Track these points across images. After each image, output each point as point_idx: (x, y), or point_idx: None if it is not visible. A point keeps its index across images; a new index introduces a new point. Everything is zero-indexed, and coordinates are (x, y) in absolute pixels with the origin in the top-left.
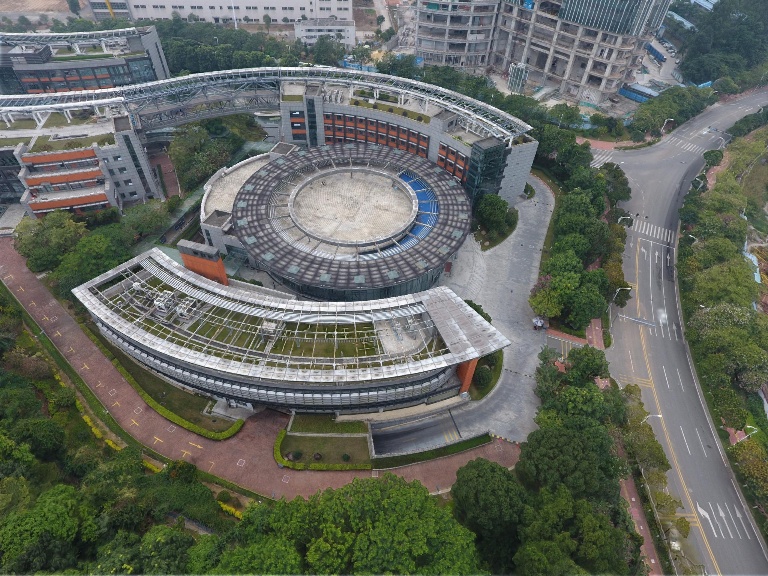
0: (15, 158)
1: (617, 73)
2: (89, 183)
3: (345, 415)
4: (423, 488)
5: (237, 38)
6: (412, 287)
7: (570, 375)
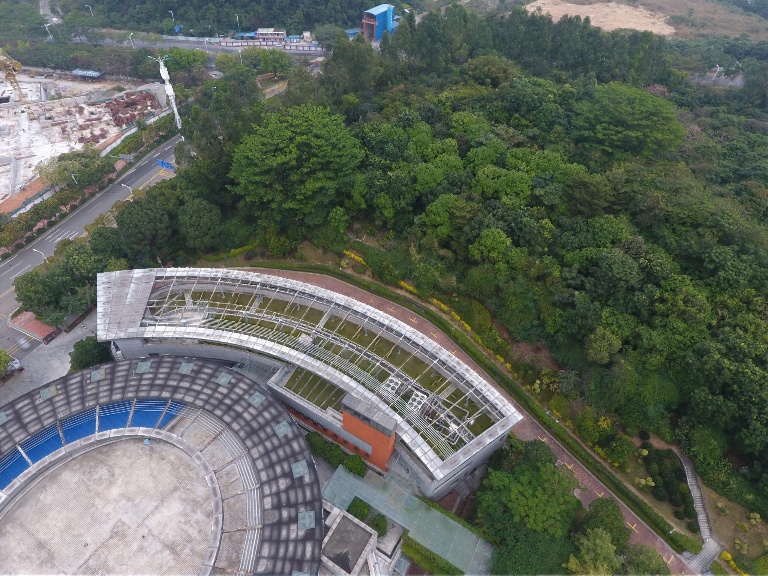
0: None
1: None
2: None
3: None
4: (241, 180)
5: None
6: None
7: (66, 278)
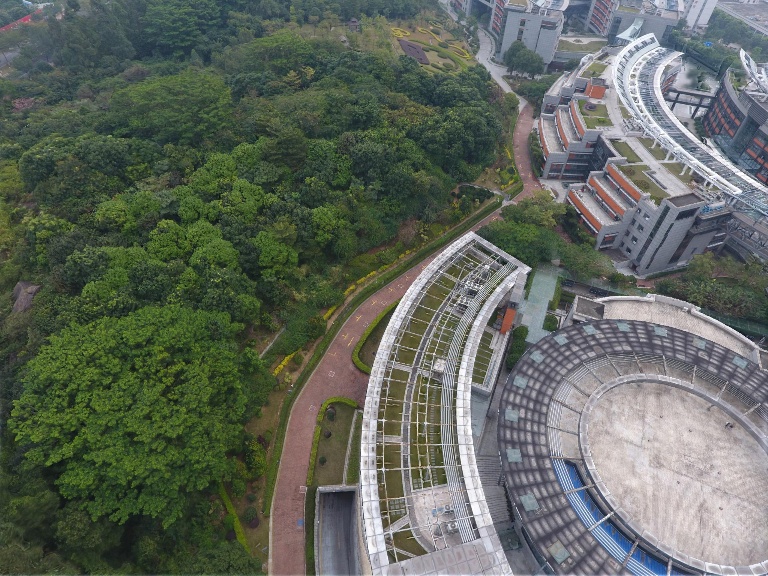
0: None
1: None
2: None
3: None
4: (203, 464)
5: None
6: None
7: None
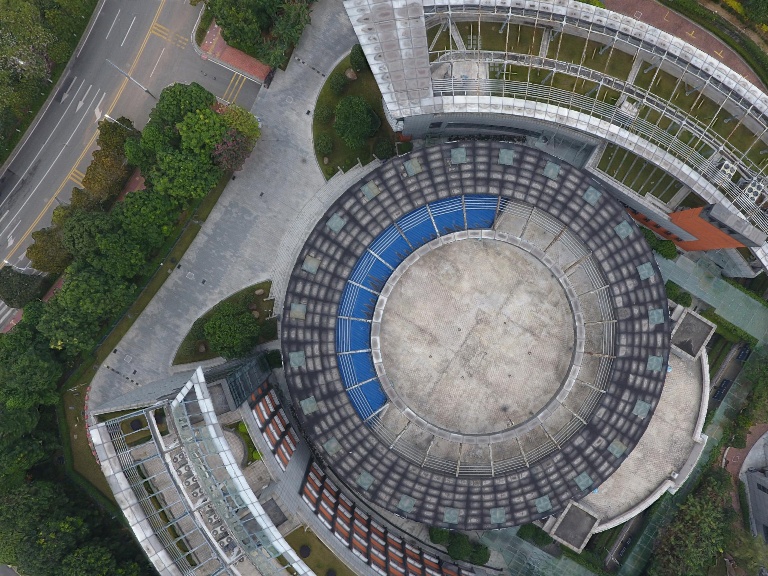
0: None
1: None
2: None
3: None
4: None
5: None
6: None
7: None
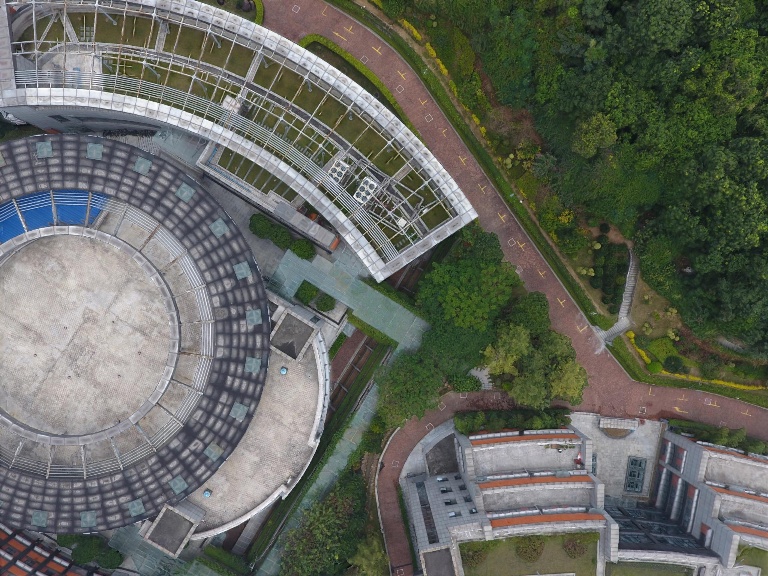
0: None
1: None
2: None
3: None
4: None
5: None
6: None
7: None
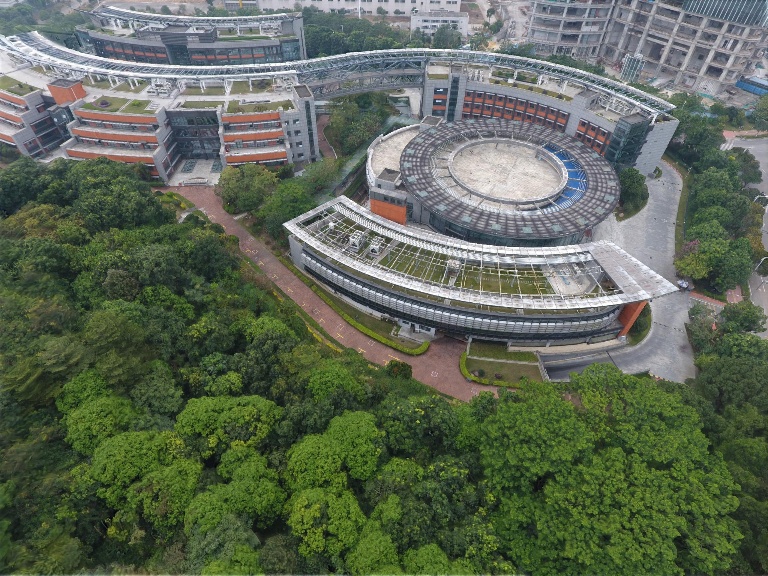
0: (212, 118)
1: (739, 64)
2: (271, 142)
3: (515, 346)
4: None
5: (361, 27)
6: (563, 245)
7: (730, 325)
